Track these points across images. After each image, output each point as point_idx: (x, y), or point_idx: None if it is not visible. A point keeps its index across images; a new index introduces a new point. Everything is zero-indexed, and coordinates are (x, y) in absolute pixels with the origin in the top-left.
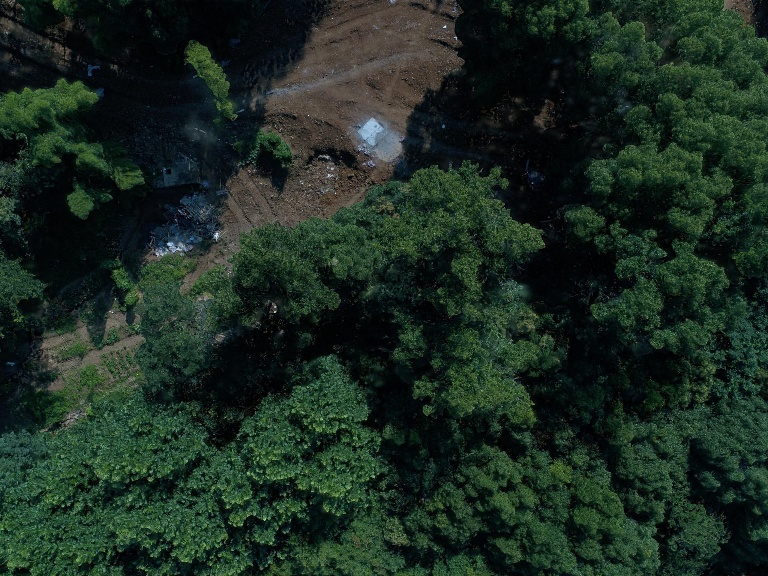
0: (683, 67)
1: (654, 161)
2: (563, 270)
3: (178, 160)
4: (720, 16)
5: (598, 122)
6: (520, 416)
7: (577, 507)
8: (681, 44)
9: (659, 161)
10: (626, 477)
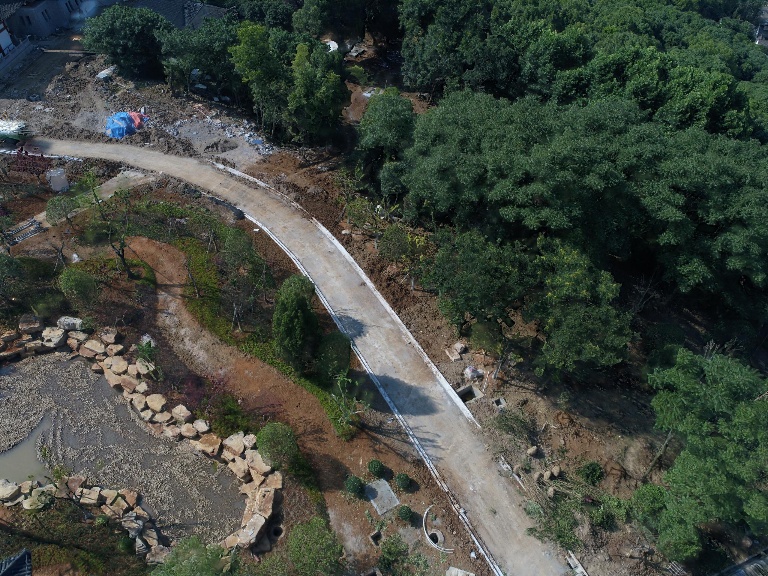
0: None
1: None
2: None
3: None
4: None
5: (374, 4)
6: (495, 12)
7: (527, 3)
8: None
9: None
10: (511, 0)
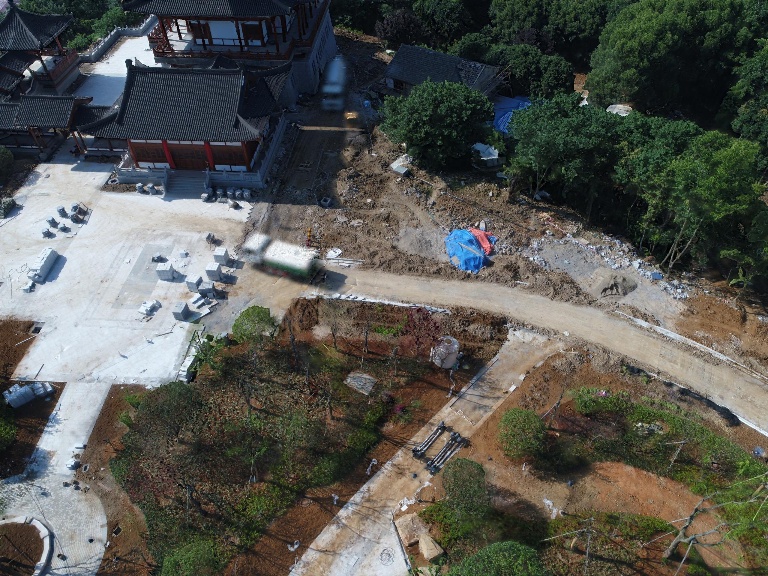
0: (673, 3)
1: (720, 5)
2: (708, 124)
3: (762, 257)
4: (643, 1)
5: None
6: None
7: None
8: (659, 8)
9: (719, 3)
10: None
